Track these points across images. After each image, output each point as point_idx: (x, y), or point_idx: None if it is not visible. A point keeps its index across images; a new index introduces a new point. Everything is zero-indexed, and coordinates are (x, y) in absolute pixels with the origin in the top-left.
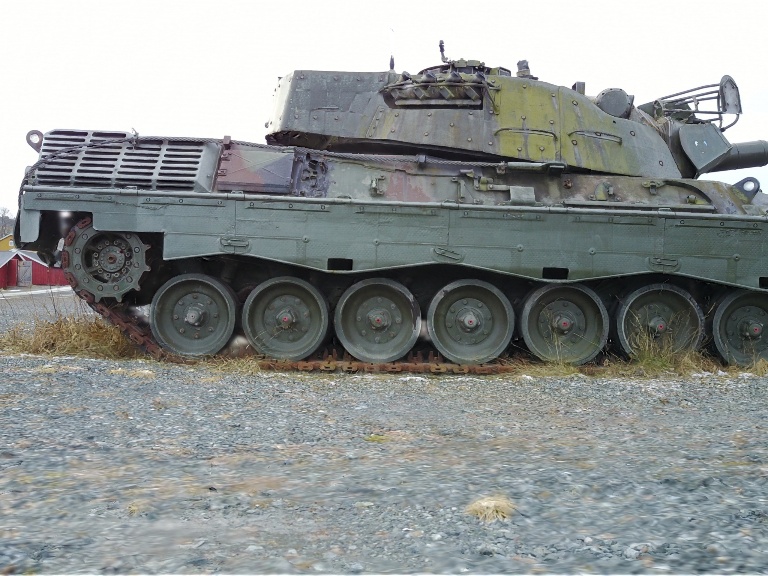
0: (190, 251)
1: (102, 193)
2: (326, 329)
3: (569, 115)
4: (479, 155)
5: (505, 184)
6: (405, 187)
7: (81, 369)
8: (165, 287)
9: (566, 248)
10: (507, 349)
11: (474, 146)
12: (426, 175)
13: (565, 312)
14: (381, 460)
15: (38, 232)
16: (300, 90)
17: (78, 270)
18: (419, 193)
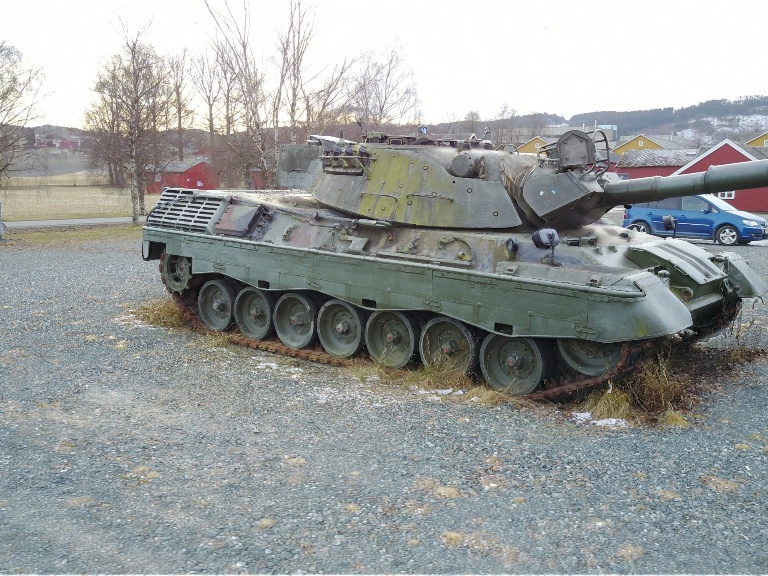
0: (202, 269)
1: (169, 233)
2: (270, 322)
3: (415, 179)
4: (349, 212)
5: (357, 235)
6: (303, 234)
7: (112, 338)
8: (204, 287)
9: (375, 286)
10: (360, 350)
11: (345, 206)
12: (319, 225)
13: (398, 329)
14: (5, 414)
15: (148, 253)
16: (284, 158)
17: (166, 274)
18: (308, 239)
